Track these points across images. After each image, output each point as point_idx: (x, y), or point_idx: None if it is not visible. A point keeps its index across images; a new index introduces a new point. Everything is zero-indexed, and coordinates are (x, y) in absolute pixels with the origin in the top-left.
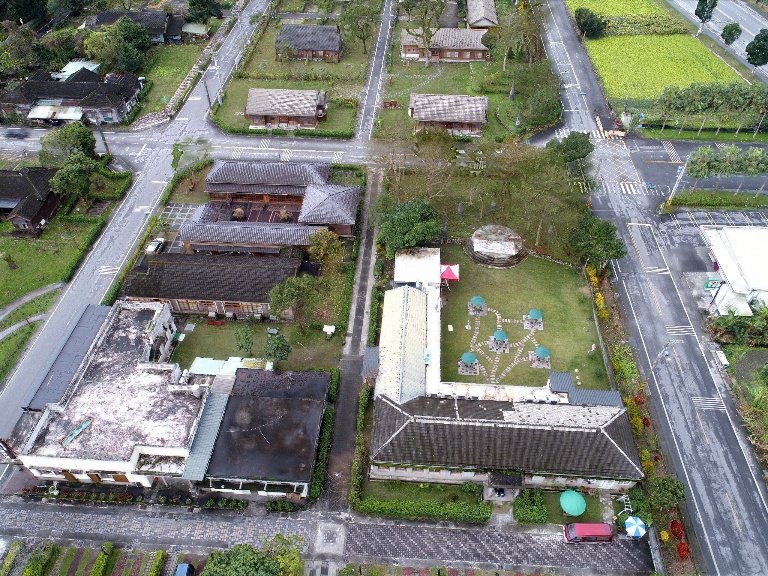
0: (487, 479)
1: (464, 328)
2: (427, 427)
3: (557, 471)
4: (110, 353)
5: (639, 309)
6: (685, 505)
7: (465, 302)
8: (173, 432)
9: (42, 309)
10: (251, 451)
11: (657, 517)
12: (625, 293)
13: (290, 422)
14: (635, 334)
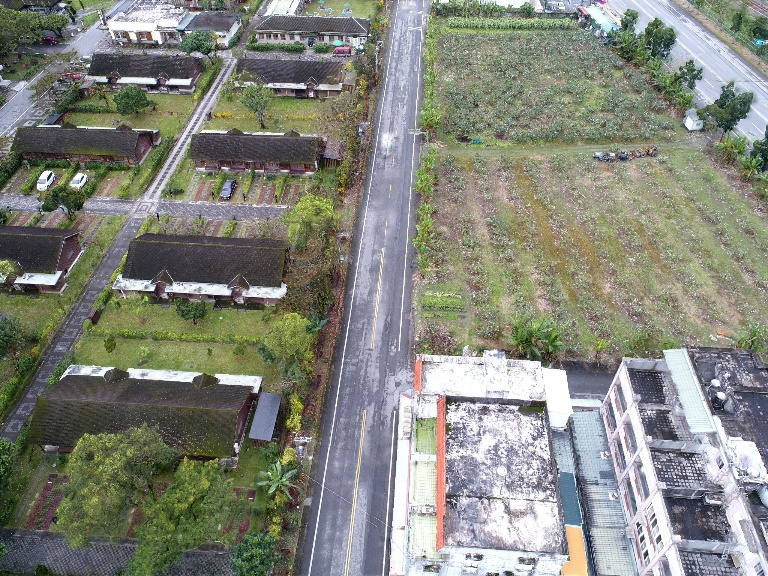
0: (306, 42)
1: (313, 13)
2: (279, 18)
3: (332, 31)
4: (143, 5)
5: (401, 7)
6: (387, 48)
7: (317, 6)
8: None
9: (108, 7)
10: (204, 25)
11: None
12: (397, 3)
13: (222, 20)
14: (394, 13)
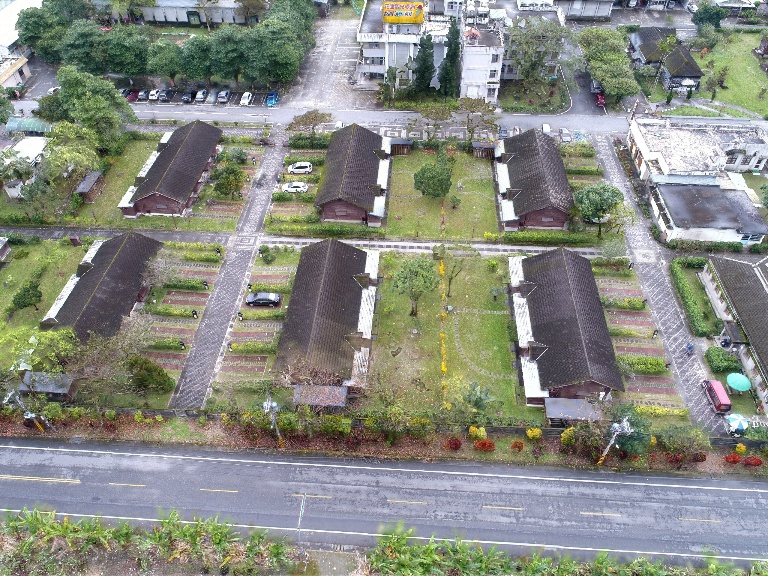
0: None
1: None
2: (753, 275)
3: (761, 362)
4: (718, 135)
5: None
6: None
7: None
8: (678, 167)
9: (736, 116)
10: (683, 199)
11: (760, 458)
12: None
13: (715, 214)
14: None
